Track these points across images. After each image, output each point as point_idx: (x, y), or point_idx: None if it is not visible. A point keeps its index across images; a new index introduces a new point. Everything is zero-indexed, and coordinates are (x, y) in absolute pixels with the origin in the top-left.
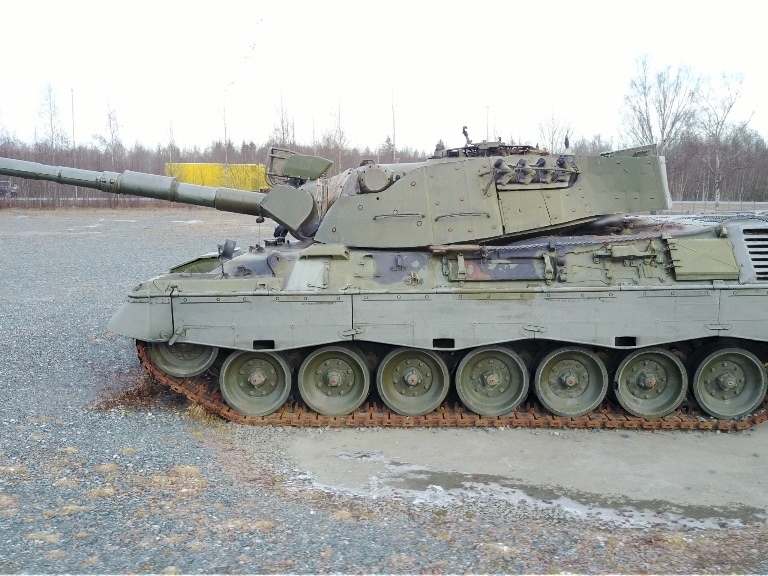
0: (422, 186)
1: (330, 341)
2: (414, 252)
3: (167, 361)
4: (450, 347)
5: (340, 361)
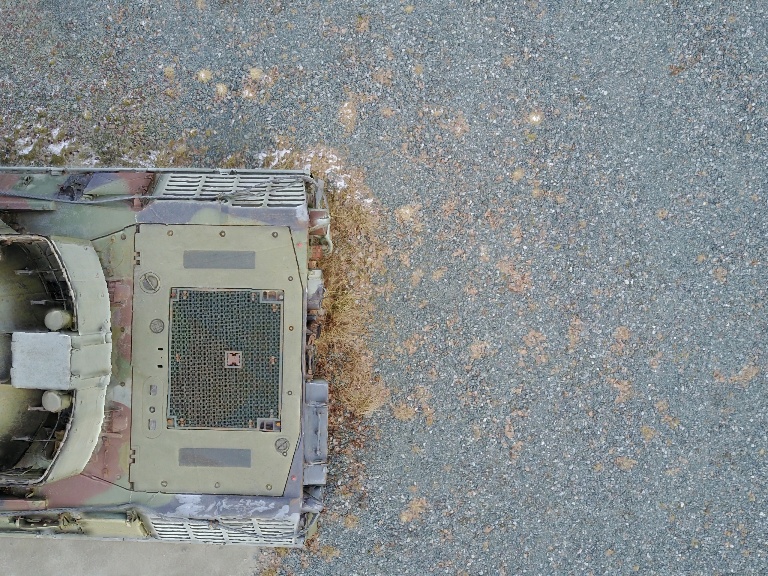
0: None
1: None
2: None
3: None
4: None
5: None
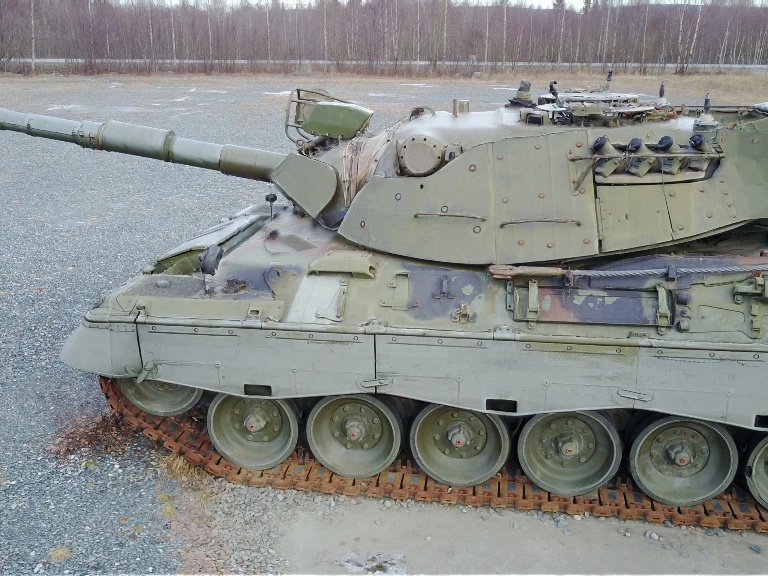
0: (484, 173)
1: (345, 392)
2: (467, 271)
3: (142, 393)
4: (510, 411)
5: (363, 407)
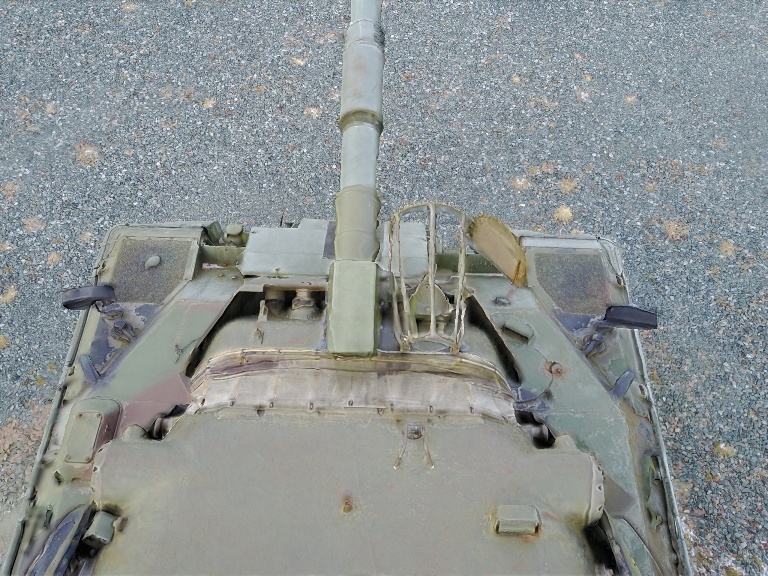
0: None
1: None
2: None
3: None
4: None
5: None
